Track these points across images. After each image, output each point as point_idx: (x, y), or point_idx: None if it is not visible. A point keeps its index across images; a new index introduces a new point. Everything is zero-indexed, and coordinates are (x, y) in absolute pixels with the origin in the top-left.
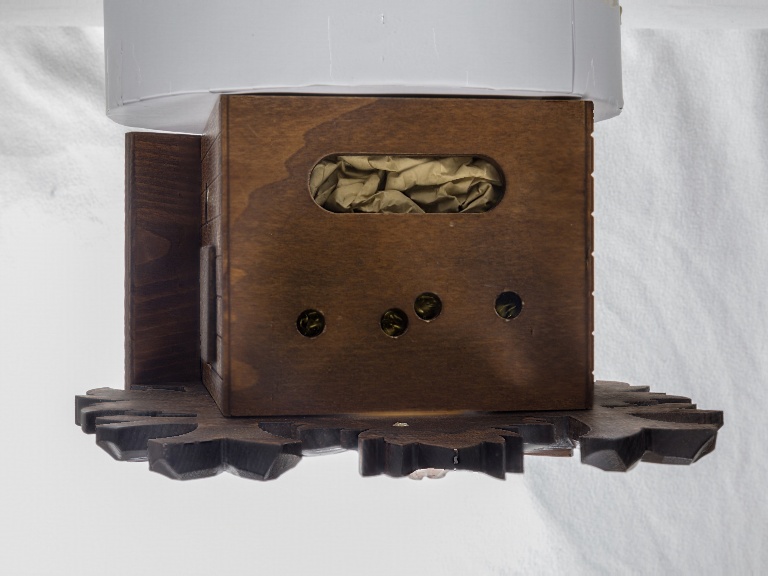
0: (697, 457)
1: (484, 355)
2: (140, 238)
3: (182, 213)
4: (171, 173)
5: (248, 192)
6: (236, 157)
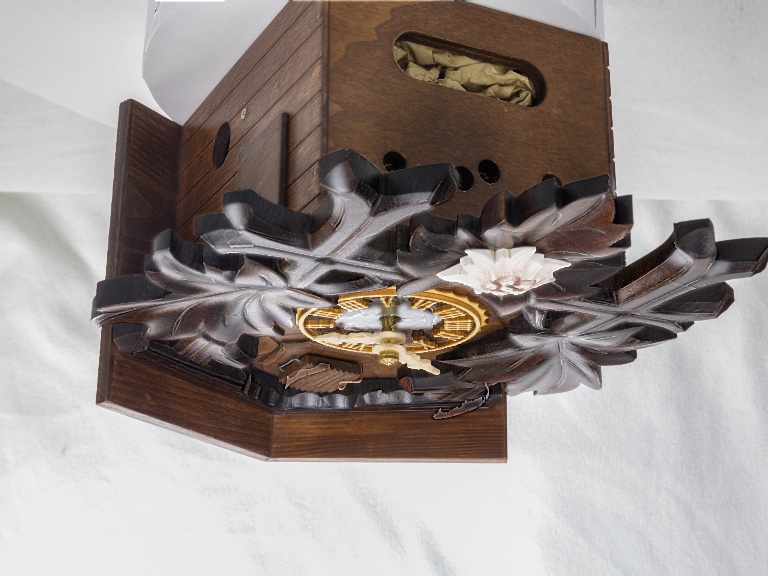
0: (756, 267)
1: None
2: (130, 193)
3: (163, 186)
4: (157, 148)
5: (345, 44)
6: (336, 13)
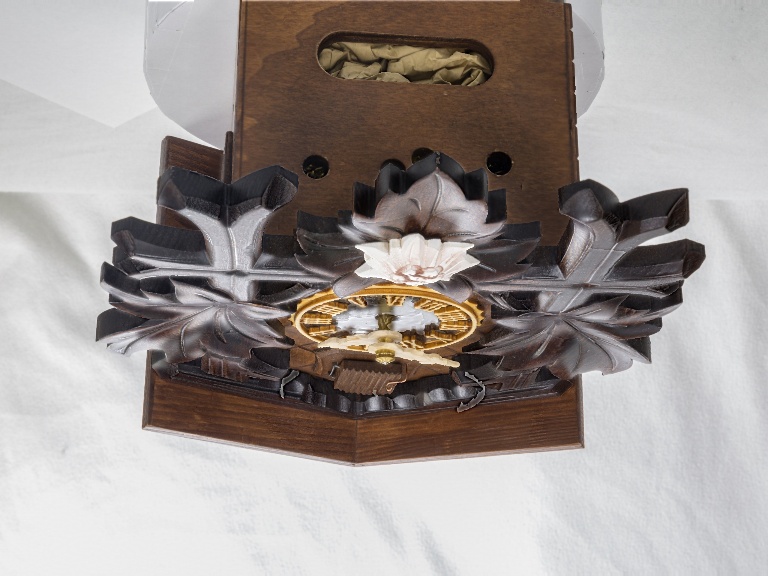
0: (672, 221)
1: None
2: (169, 225)
3: None
4: None
5: (262, 57)
6: (253, 29)
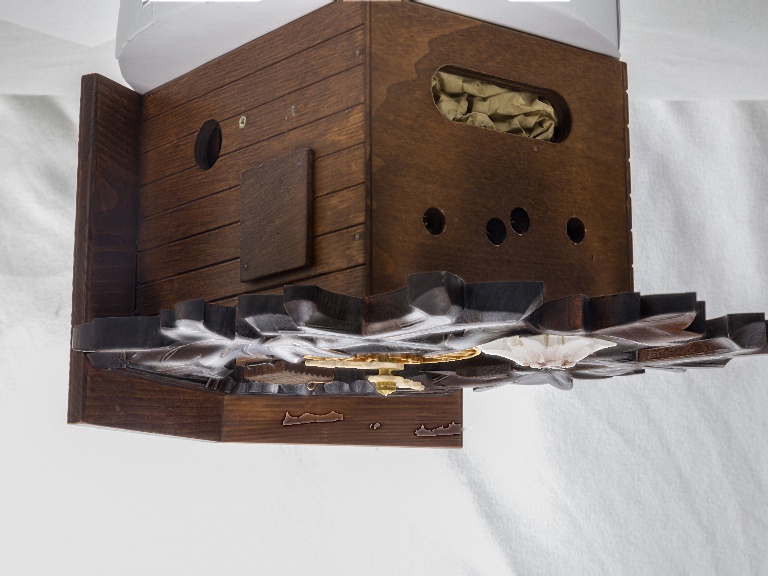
0: None
1: (560, 273)
2: (98, 184)
3: (127, 169)
4: (121, 125)
5: (386, 86)
6: (377, 50)
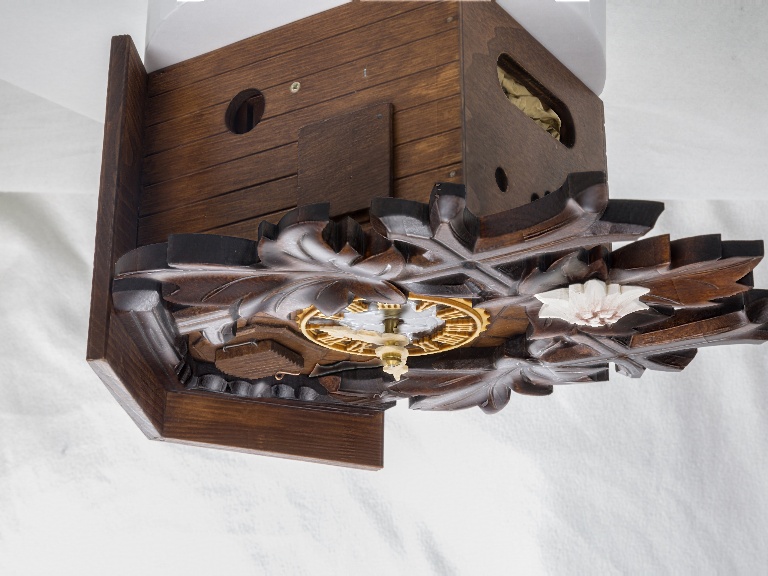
0: None
1: None
2: (125, 137)
3: (138, 135)
4: (137, 93)
5: (472, 52)
6: (466, 20)
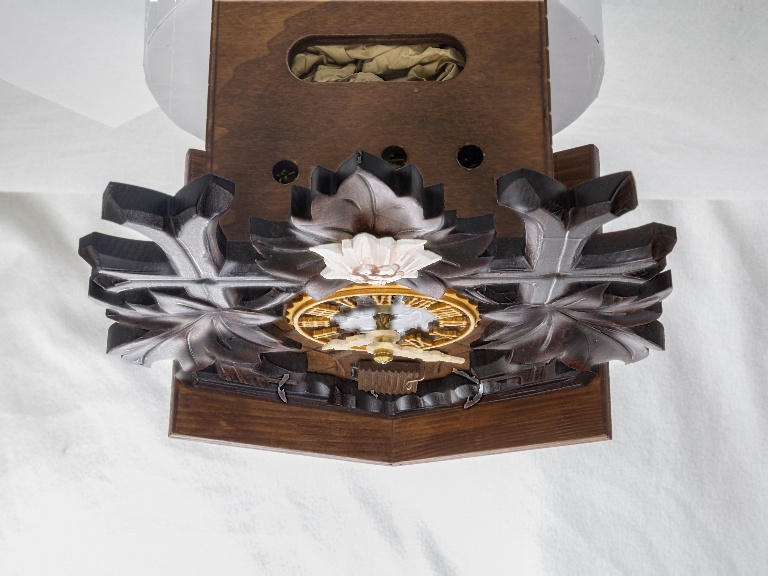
0: (618, 206)
1: (447, 199)
2: None
3: None
4: None
5: (233, 66)
6: (224, 40)
